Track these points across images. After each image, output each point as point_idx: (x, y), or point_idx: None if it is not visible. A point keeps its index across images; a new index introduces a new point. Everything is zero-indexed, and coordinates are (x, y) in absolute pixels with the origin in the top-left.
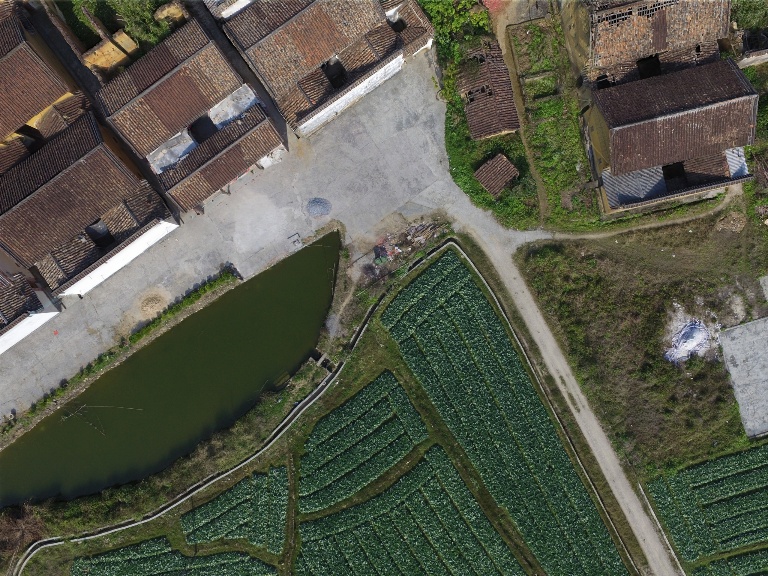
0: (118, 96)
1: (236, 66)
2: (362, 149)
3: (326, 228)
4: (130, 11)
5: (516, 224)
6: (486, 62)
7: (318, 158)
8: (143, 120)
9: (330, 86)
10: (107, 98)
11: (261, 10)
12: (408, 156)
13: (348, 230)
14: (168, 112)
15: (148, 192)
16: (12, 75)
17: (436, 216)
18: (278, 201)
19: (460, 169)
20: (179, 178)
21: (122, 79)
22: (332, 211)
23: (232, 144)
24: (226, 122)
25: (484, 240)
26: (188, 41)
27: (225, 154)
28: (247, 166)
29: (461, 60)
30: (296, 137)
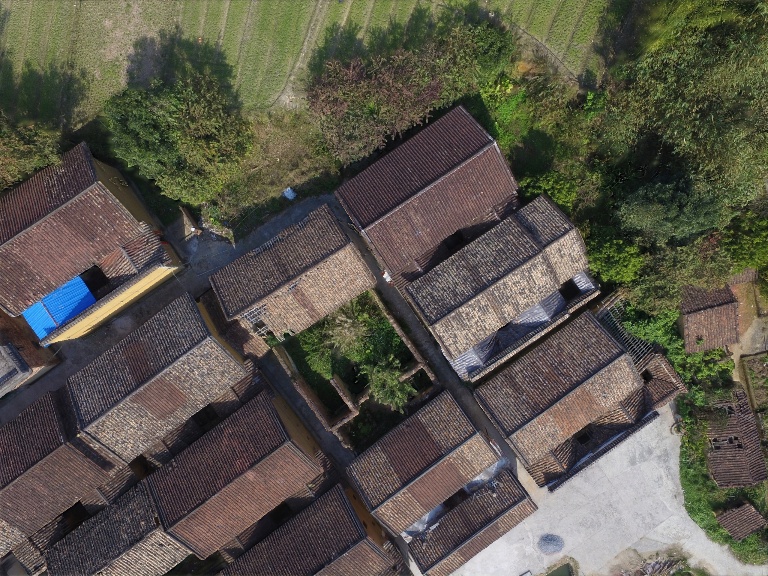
0: (377, 481)
1: (465, 402)
2: (594, 484)
3: (558, 564)
4: (378, 380)
5: (754, 560)
6: (736, 416)
7: (549, 493)
8: (403, 506)
9: (575, 439)
10: (363, 480)
11: (516, 381)
12: (642, 491)
13: (581, 567)
14: (427, 495)
15: (392, 555)
16: (272, 469)
17: (671, 552)
18: (509, 538)
19: (697, 505)
20: (435, 556)
21: (376, 457)
22: (564, 547)
23: (491, 524)
24: (472, 482)
25: (721, 575)
26: (448, 423)
27: (483, 532)
28: (500, 536)
29: (706, 407)
30: (526, 472)
